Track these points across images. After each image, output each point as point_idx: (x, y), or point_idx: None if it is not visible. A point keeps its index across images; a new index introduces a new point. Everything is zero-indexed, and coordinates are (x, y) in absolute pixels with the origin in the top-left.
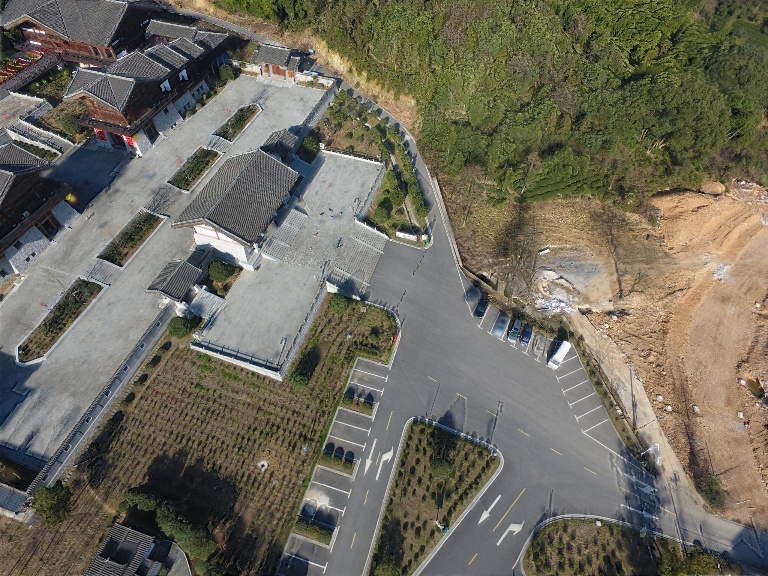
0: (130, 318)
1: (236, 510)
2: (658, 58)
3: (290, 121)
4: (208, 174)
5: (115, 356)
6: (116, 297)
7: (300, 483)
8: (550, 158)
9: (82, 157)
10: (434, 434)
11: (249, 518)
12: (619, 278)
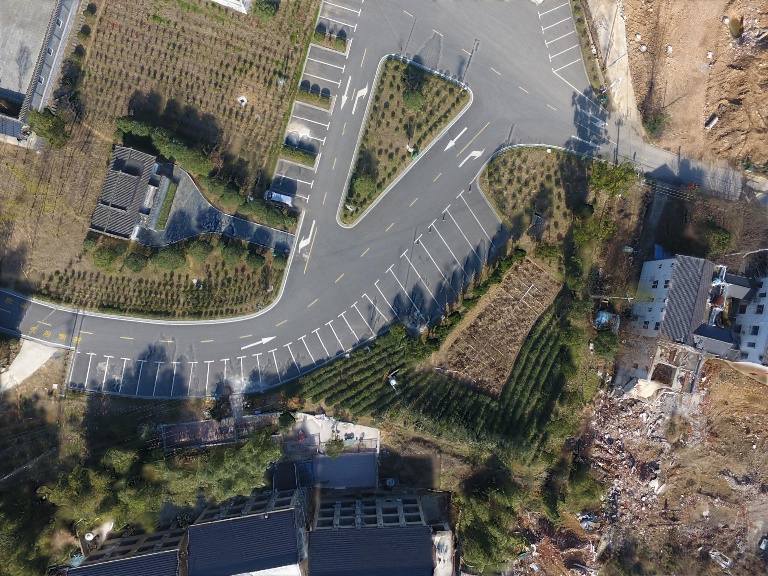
0: None
1: (225, 139)
2: None
3: None
4: None
5: None
6: None
7: (281, 117)
8: None
9: None
10: (408, 71)
11: (238, 146)
12: None
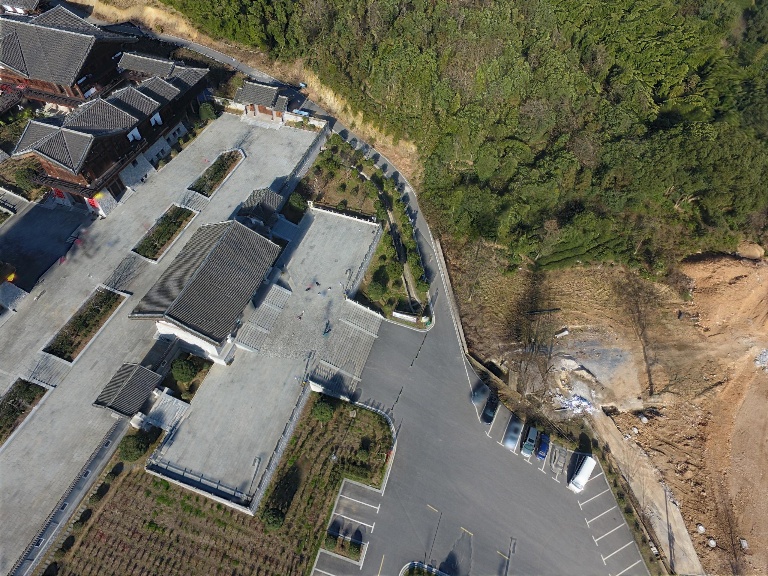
0: (76, 432)
1: None
2: (685, 95)
3: (276, 171)
4: (180, 238)
5: (54, 486)
6: (62, 403)
7: None
8: (568, 218)
9: (37, 218)
10: None
11: None
12: (648, 368)
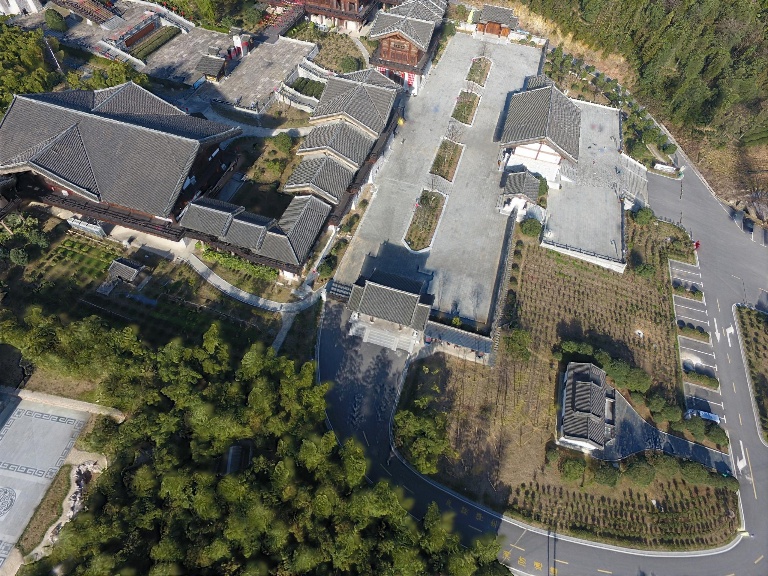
0: (481, 221)
1: (637, 363)
2: None
3: (522, 72)
4: (478, 112)
5: (487, 248)
6: (459, 205)
7: (672, 347)
8: (757, 110)
9: None
10: (760, 315)
11: (649, 369)
12: None
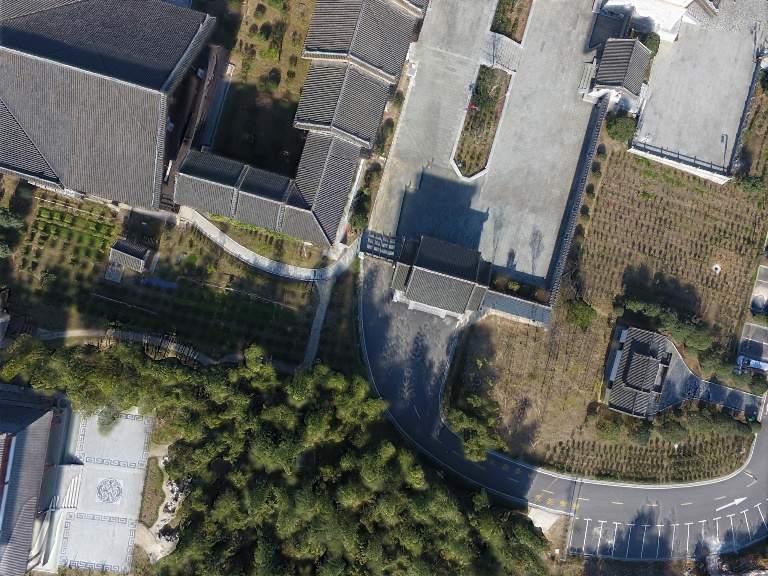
0: (556, 117)
1: (703, 308)
2: None
3: None
4: None
5: (558, 165)
6: (529, 88)
7: (748, 282)
8: None
9: None
10: None
11: (713, 313)
12: None
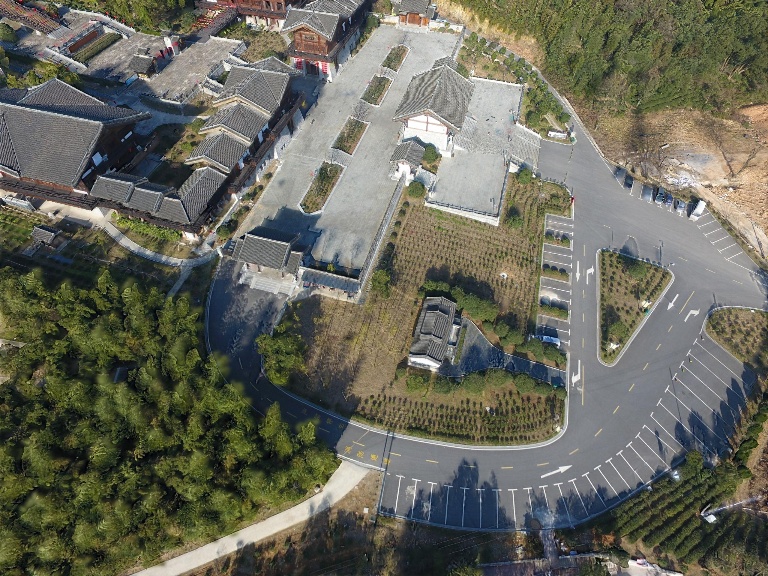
0: (373, 186)
1: (496, 300)
2: (726, 5)
3: (436, 57)
4: (387, 94)
5: (373, 209)
6: (356, 174)
7: (533, 286)
8: None
9: None
10: (620, 257)
11: (506, 304)
12: (728, 163)
